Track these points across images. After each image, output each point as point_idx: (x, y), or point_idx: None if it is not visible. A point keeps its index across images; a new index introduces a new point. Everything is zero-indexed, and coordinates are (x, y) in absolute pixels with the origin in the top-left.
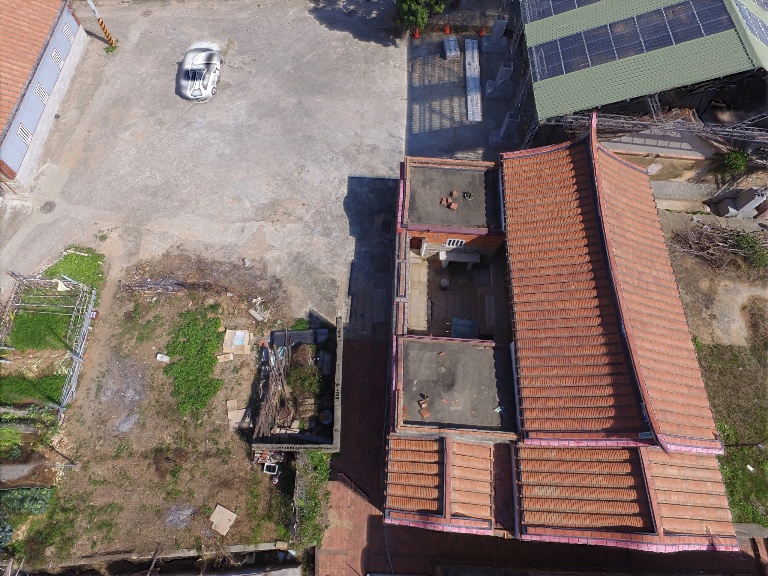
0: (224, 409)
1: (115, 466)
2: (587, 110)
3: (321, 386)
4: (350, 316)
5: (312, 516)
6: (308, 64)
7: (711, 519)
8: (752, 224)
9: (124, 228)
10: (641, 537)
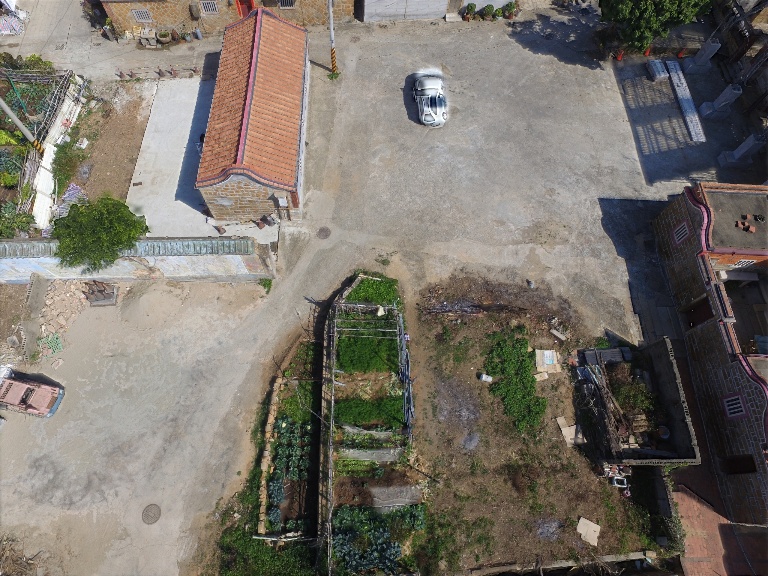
0: (555, 426)
1: (475, 482)
2: None
3: (652, 403)
4: (643, 334)
5: (679, 526)
6: (525, 88)
7: None
8: None
9: (403, 252)
10: None
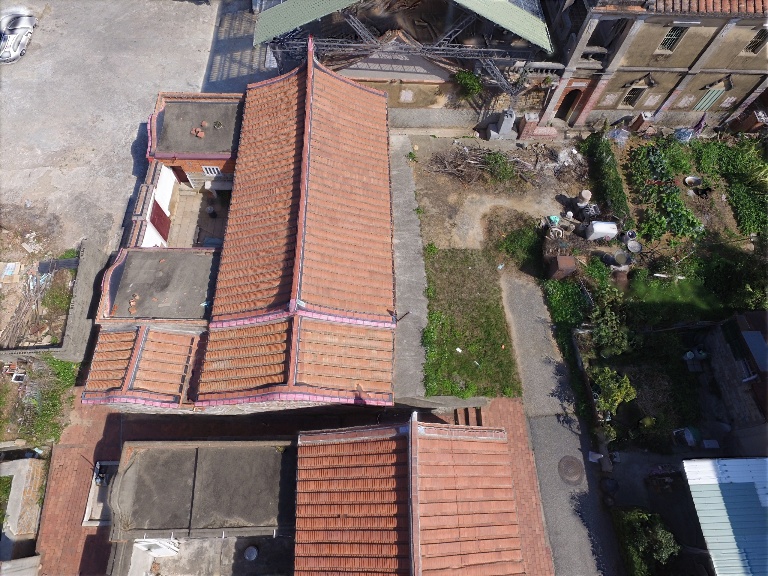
0: None
1: None
2: (294, 33)
3: None
4: (120, 245)
5: (46, 414)
6: (119, 24)
7: (368, 379)
8: (510, 144)
9: None
10: (274, 388)
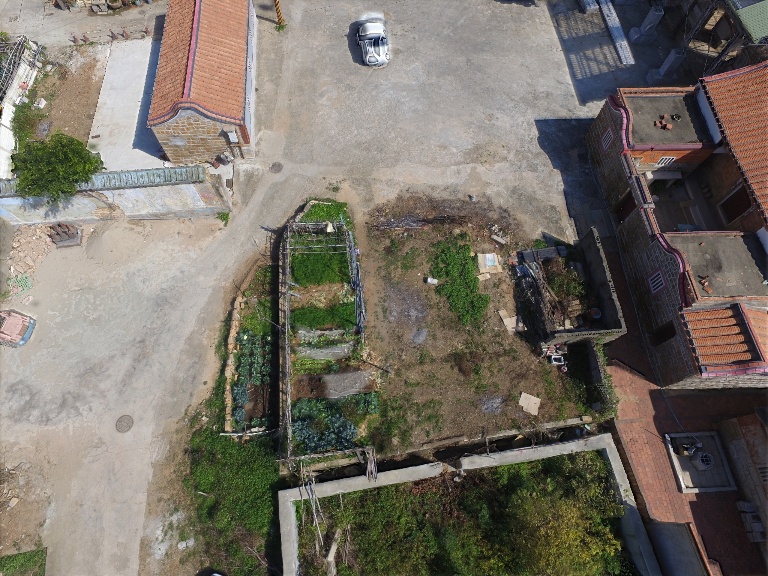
0: (498, 318)
1: (424, 370)
2: None
3: (584, 288)
4: (578, 234)
5: (611, 391)
6: (463, 27)
7: None
8: None
9: (352, 179)
10: None
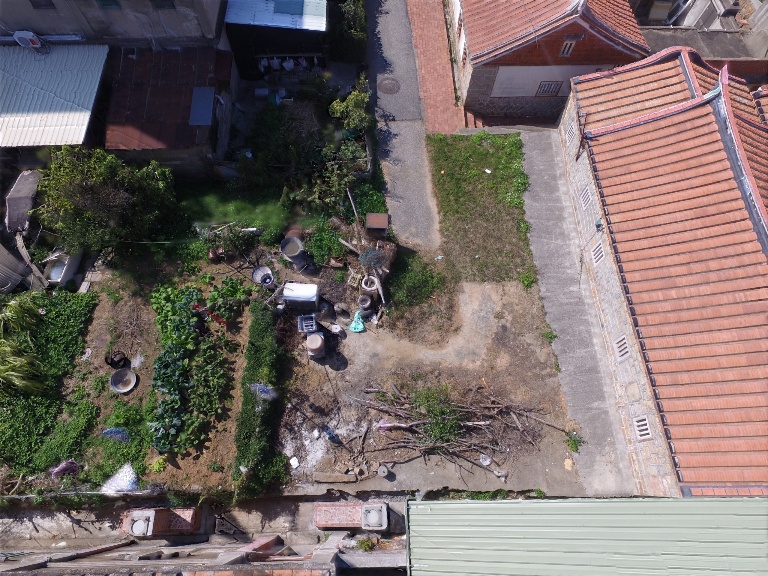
0: None
1: None
2: None
3: None
4: None
5: None
6: None
7: None
8: (407, 478)
9: None
10: None
